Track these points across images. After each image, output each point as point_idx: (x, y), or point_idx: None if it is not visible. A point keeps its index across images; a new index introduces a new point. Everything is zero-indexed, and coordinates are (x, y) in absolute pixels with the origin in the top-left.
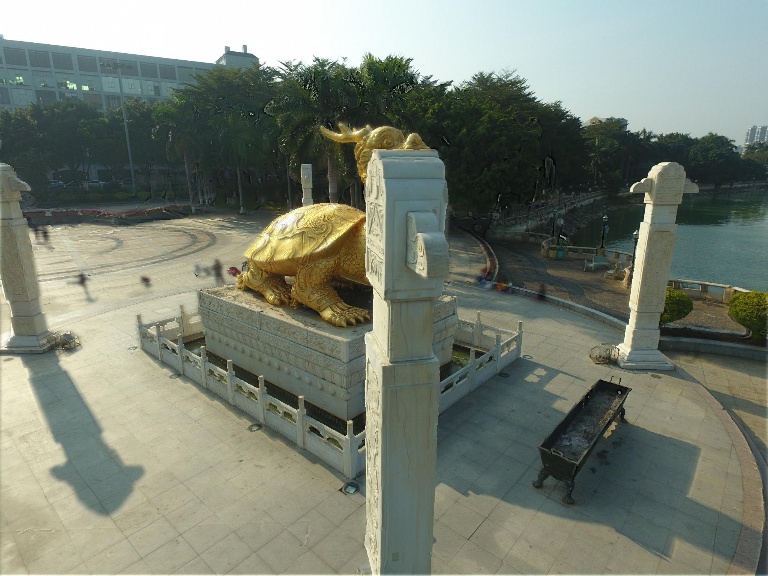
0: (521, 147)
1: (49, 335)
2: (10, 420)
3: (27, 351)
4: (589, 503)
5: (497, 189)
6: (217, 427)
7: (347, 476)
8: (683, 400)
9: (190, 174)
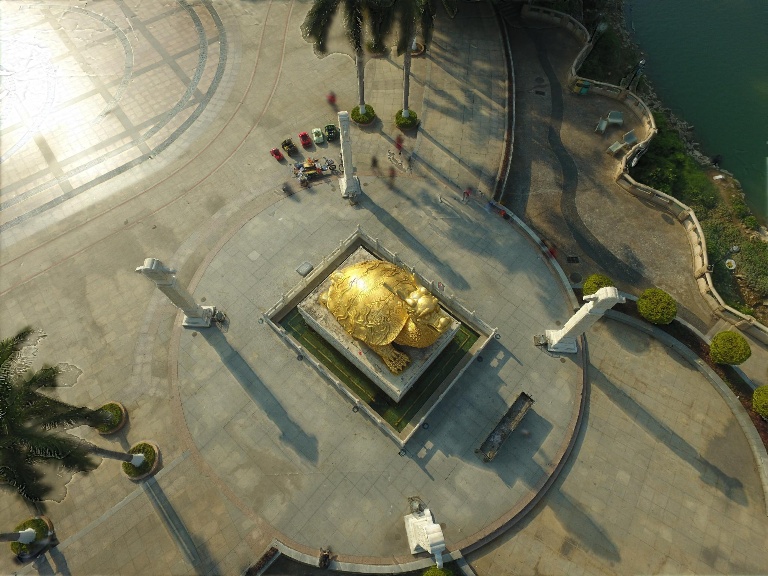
0: None
1: (206, 313)
2: (238, 402)
3: (200, 326)
4: (493, 461)
5: None
6: (338, 409)
7: (401, 446)
8: (565, 386)
9: None
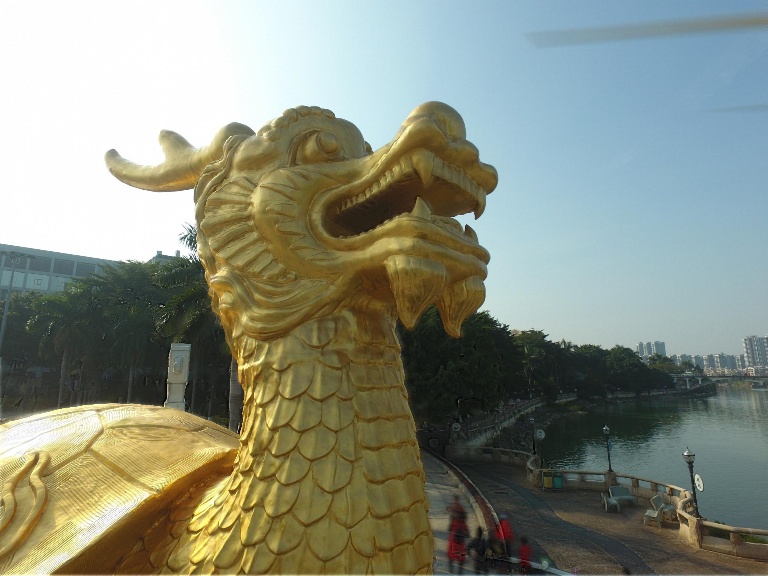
0: (476, 344)
1: None
2: None
3: None
4: None
5: (457, 392)
6: None
7: None
8: None
9: (66, 375)
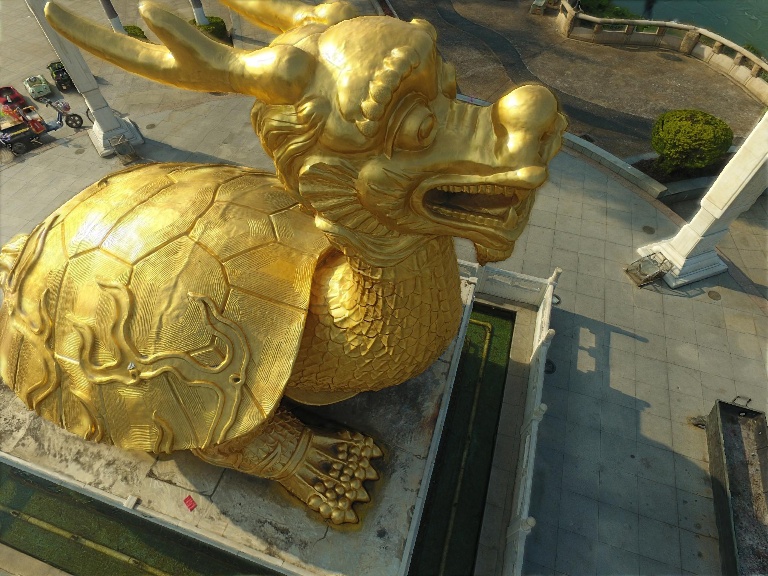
0: None
1: None
2: None
3: None
4: None
5: None
6: None
7: None
8: (765, 348)
9: None
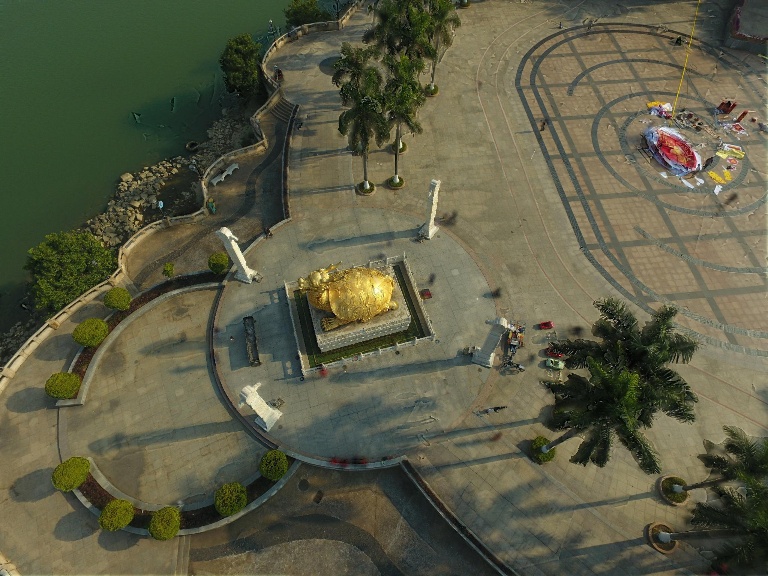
0: None
1: (427, 232)
2: (365, 230)
3: None
4: None
5: None
6: None
7: None
8: None
9: None
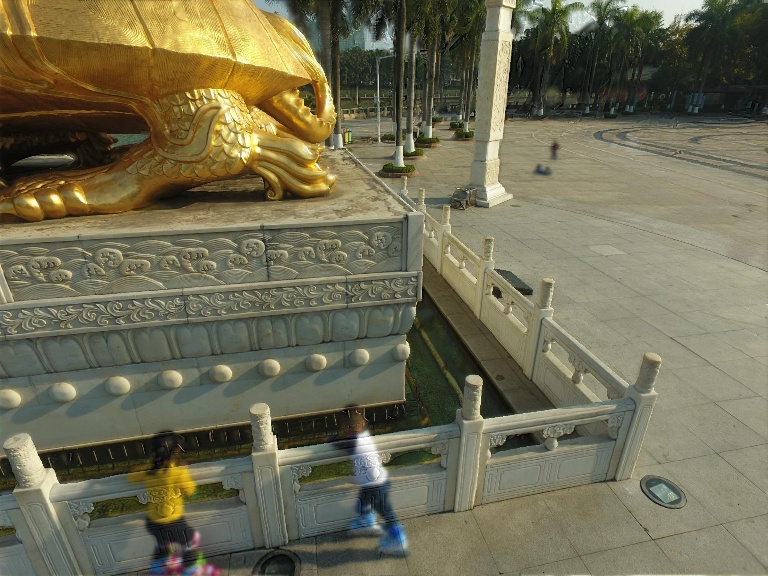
0: None
1: (478, 190)
2: None
3: None
4: None
5: None
6: None
7: None
8: None
9: None
